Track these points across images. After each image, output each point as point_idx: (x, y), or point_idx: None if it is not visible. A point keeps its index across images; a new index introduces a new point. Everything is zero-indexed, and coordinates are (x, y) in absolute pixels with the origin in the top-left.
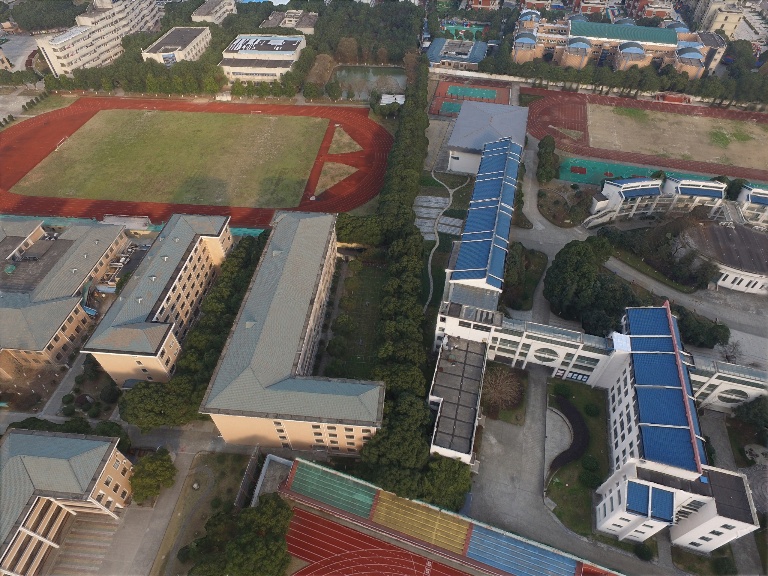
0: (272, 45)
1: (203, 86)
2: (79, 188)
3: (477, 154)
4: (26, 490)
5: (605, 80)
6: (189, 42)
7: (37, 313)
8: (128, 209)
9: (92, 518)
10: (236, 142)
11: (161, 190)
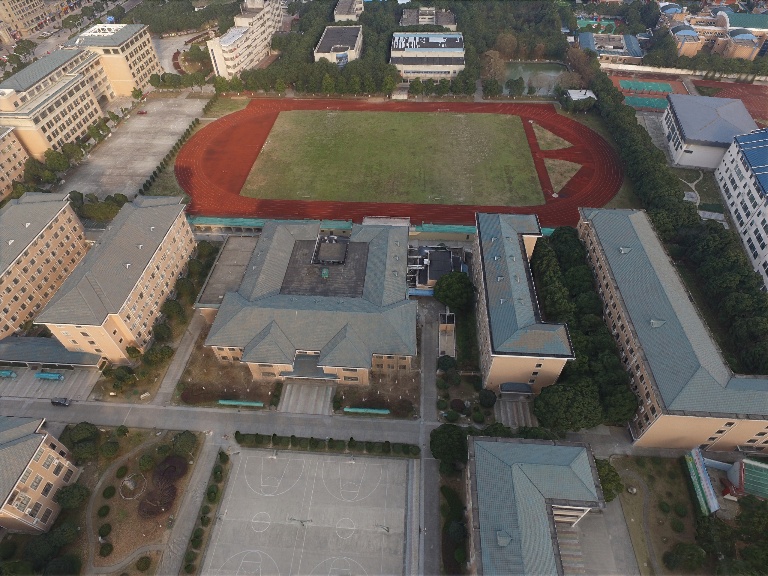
0: (435, 42)
1: (381, 85)
2: (310, 190)
3: (718, 147)
4: (539, 499)
5: None
6: (352, 41)
7: (395, 317)
8: (374, 210)
9: None
10: (440, 141)
11: (395, 190)
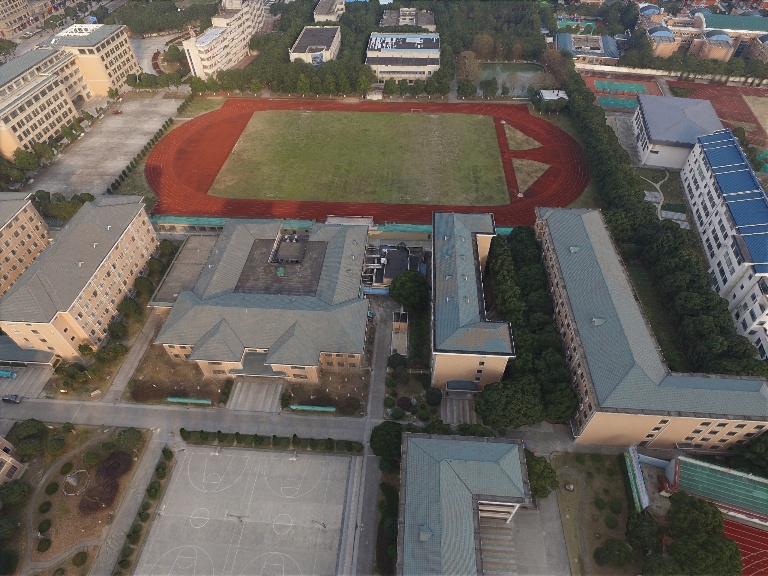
0: (412, 43)
1: (355, 85)
2: (278, 190)
3: (683, 147)
4: (466, 495)
5: (758, 72)
6: (329, 41)
7: (344, 315)
8: (339, 210)
9: (481, 522)
10: (411, 141)
11: (362, 190)
